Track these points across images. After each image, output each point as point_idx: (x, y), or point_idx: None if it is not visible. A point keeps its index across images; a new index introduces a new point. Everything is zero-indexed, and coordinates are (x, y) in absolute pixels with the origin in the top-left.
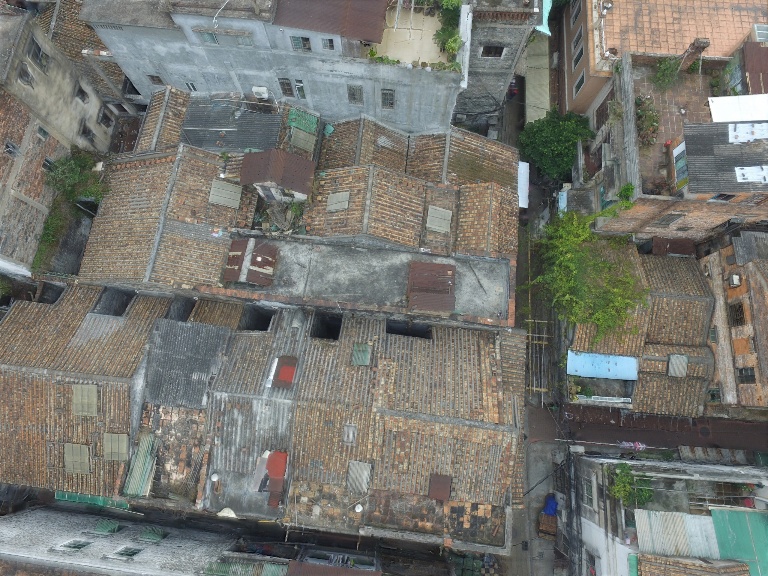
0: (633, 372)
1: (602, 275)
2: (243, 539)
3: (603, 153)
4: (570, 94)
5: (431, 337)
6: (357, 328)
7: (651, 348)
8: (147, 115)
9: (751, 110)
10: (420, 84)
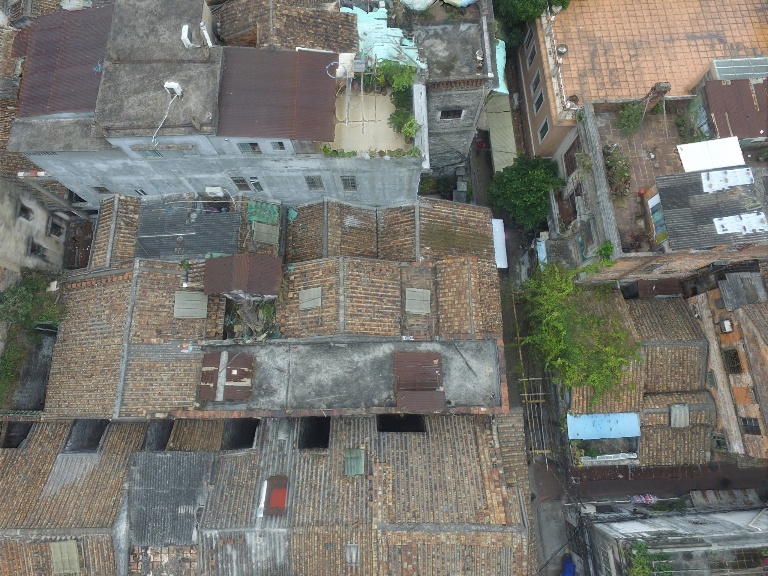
0: (635, 428)
1: (592, 332)
2: None
3: (577, 207)
4: (535, 138)
5: (425, 429)
6: (347, 430)
7: (650, 400)
8: (98, 226)
9: (722, 155)
10: (380, 169)
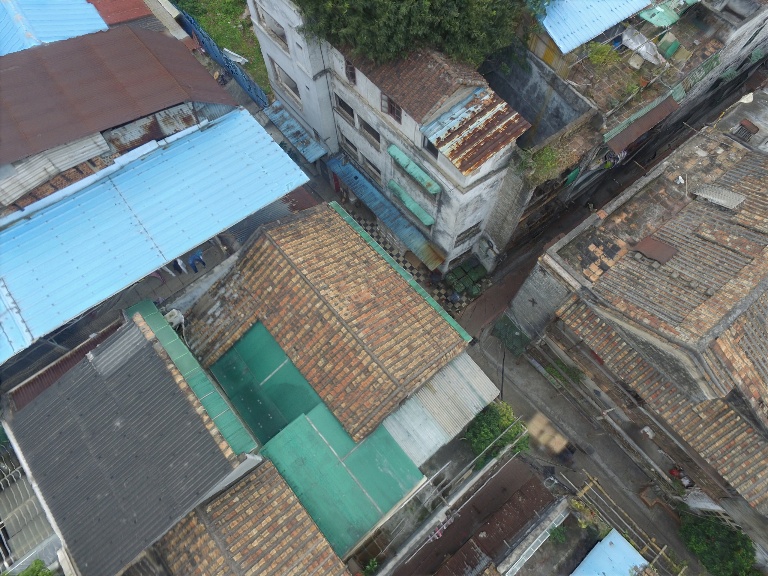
0: None
1: None
2: None
3: None
4: None
5: None
6: None
7: None
8: None
9: None
10: None
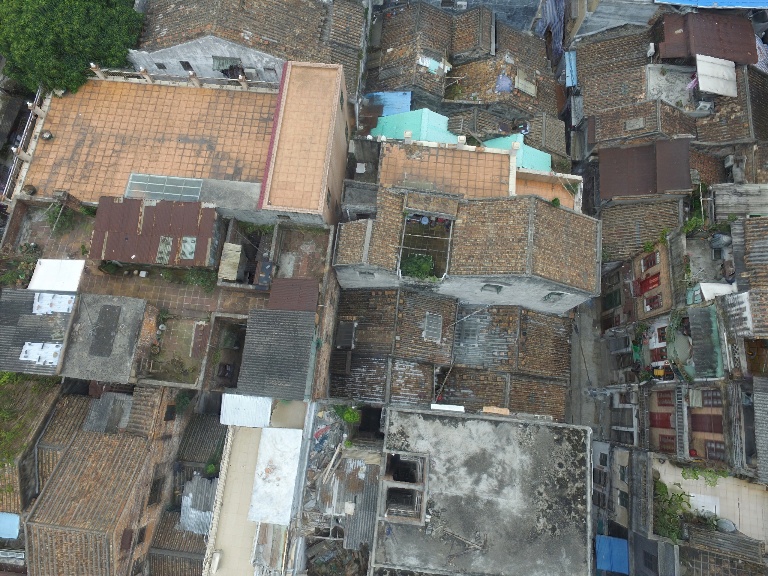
0: (13, 530)
1: None
2: None
3: None
4: None
5: None
6: None
7: None
8: None
9: (65, 277)
10: None
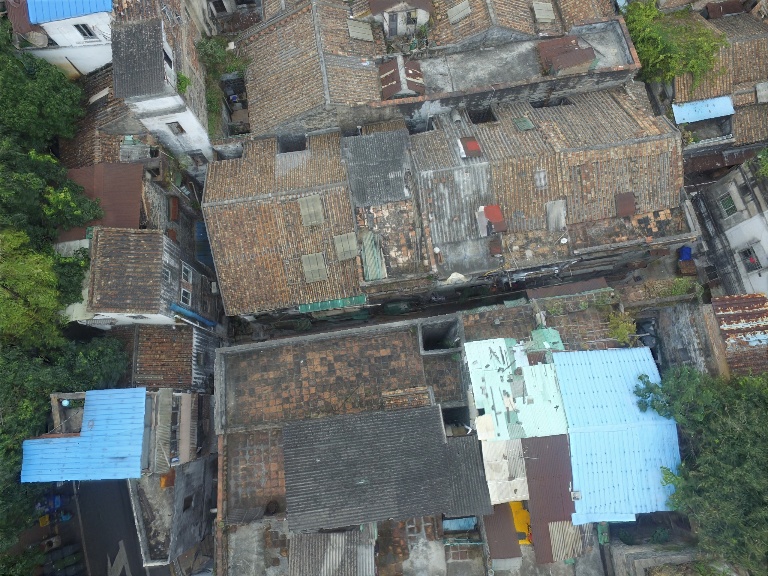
0: (729, 108)
1: (682, 35)
2: None
3: None
4: None
5: (570, 103)
6: (508, 111)
7: (737, 86)
8: None
9: None
10: None
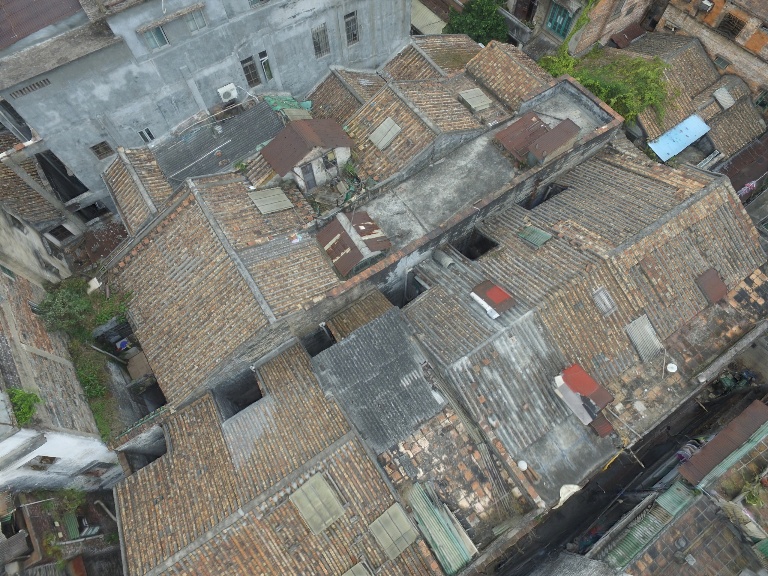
0: (703, 125)
1: (616, 73)
2: (570, 542)
3: None
4: None
5: (565, 187)
6: (501, 226)
7: (694, 101)
8: (114, 195)
9: None
10: None
